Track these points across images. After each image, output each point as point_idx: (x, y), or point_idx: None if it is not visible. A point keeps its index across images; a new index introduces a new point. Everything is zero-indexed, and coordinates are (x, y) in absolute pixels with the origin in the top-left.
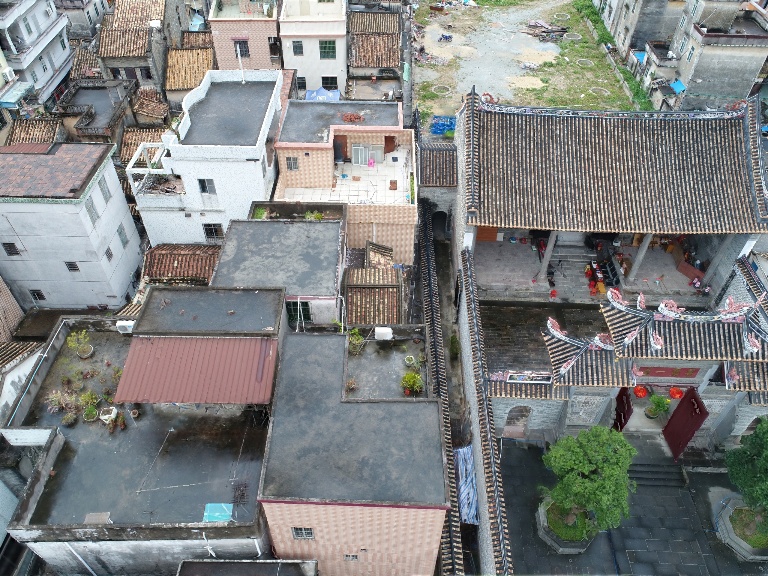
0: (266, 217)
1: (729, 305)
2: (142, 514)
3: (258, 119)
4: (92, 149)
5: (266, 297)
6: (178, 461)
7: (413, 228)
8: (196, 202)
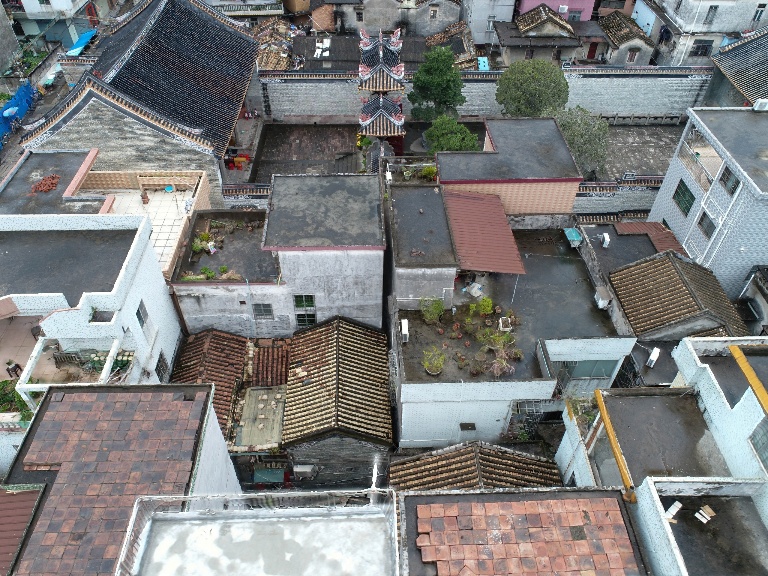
0: (198, 275)
1: (365, 45)
2: (580, 287)
3: (41, 240)
4: (63, 409)
5: (400, 195)
6: (532, 276)
7: (208, 198)
8: (144, 348)
